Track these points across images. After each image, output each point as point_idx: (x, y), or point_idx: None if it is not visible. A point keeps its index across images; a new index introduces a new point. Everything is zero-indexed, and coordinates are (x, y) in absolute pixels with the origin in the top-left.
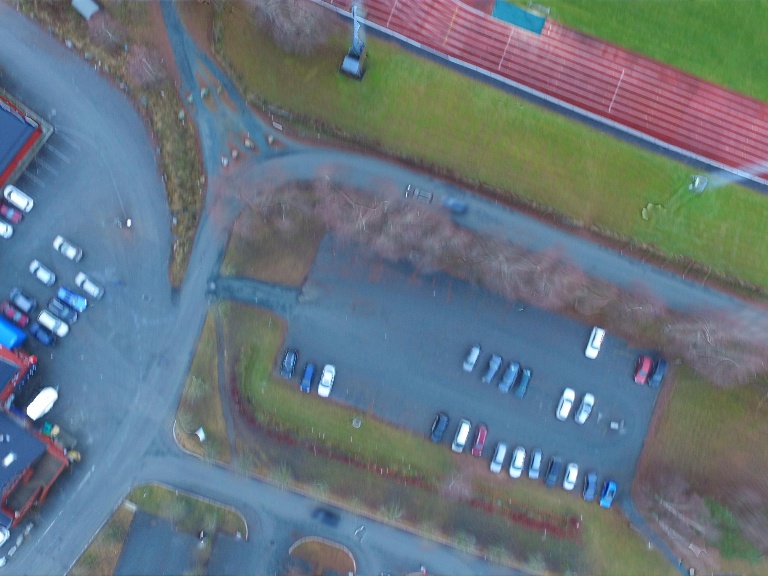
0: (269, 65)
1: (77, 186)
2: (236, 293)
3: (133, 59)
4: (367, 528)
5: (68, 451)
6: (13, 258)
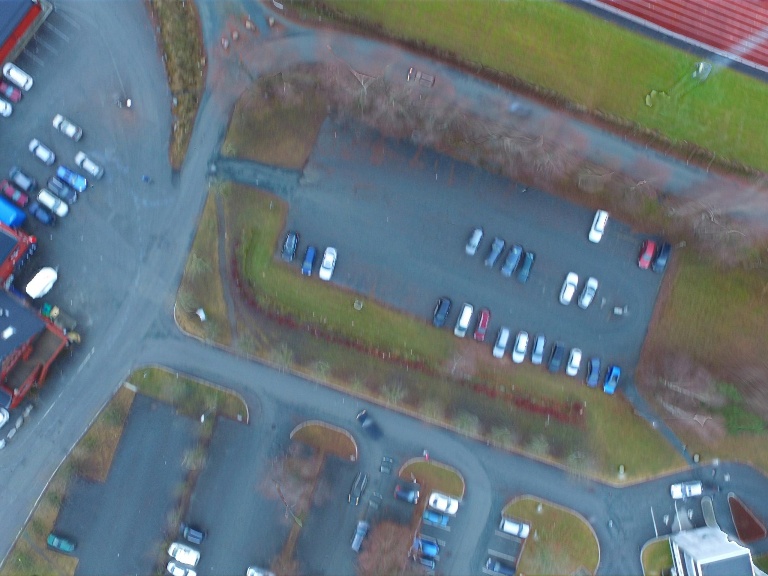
0: None
1: (77, 65)
2: (237, 175)
3: None
4: (369, 412)
5: (68, 332)
6: (12, 137)
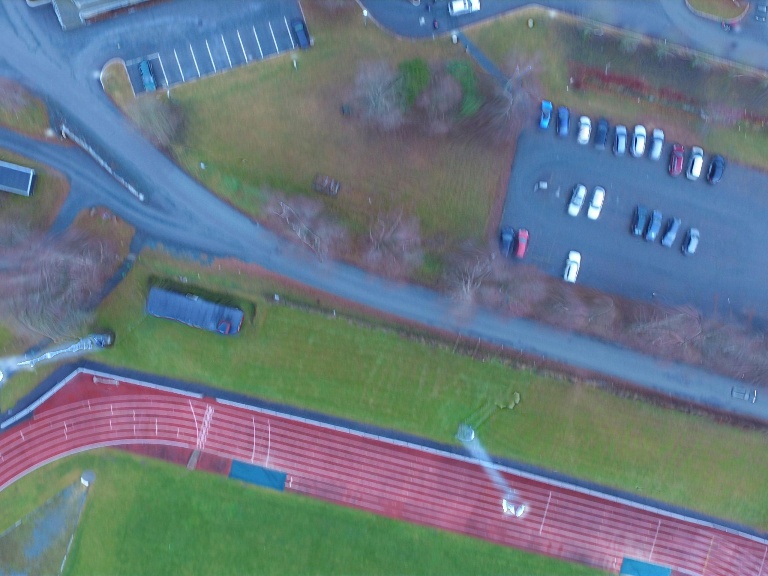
0: None
1: None
2: None
3: None
4: None
5: None
6: None
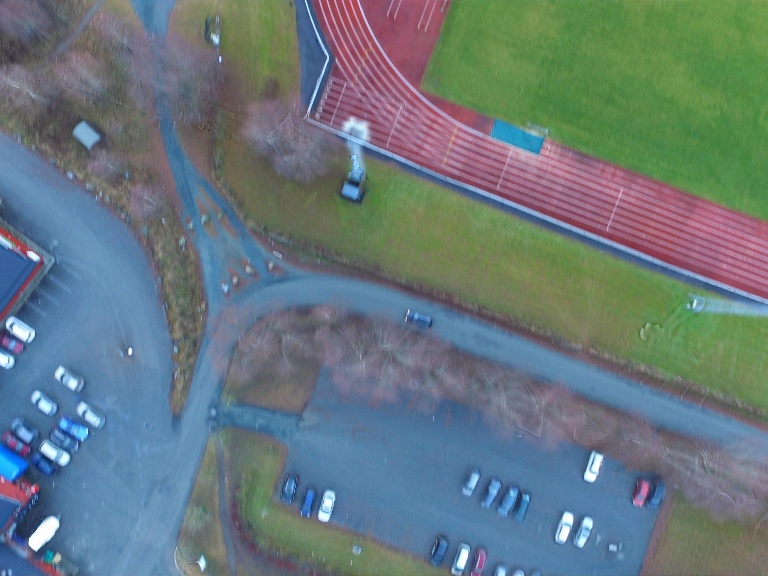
0: (269, 190)
1: (78, 316)
2: (237, 419)
3: (134, 187)
4: None
5: None
6: (15, 388)
